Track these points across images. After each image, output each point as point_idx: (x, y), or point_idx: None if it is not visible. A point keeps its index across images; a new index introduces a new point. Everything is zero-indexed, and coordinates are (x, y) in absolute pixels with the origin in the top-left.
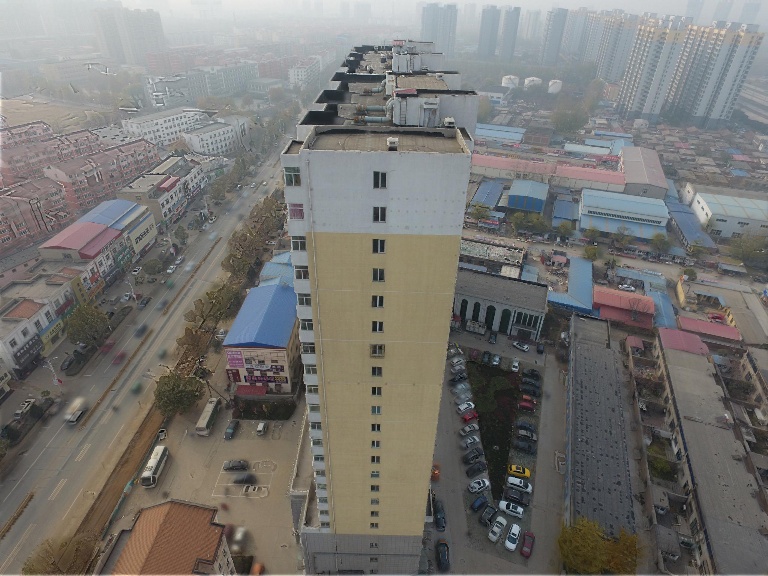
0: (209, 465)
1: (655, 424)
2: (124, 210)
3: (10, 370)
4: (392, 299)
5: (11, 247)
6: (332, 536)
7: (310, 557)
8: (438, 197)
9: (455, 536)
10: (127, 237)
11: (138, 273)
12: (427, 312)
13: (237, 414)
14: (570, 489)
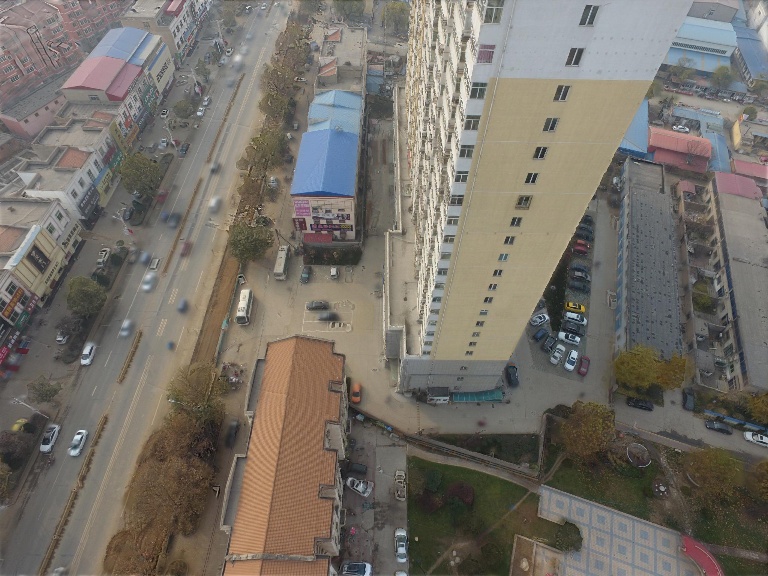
0: (293, 305)
1: (700, 265)
2: (137, 41)
3: (76, 221)
4: (556, 150)
5: (22, 87)
6: (430, 362)
7: (406, 378)
8: (646, 36)
9: (521, 360)
10: (148, 74)
11: (167, 116)
12: (586, 163)
13: (308, 260)
14: (626, 322)
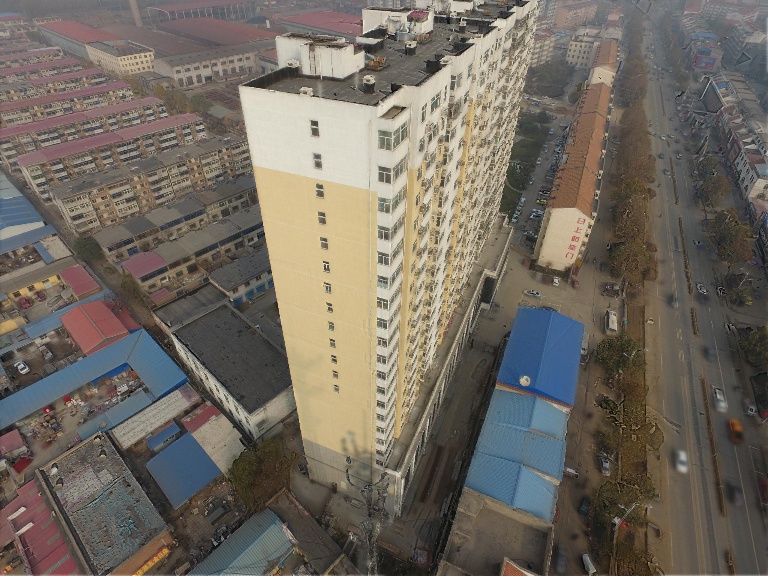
0: None
1: None
2: None
3: None
4: None
5: None
6: None
7: None
8: None
9: None
10: None
11: None
12: None
13: None
14: None
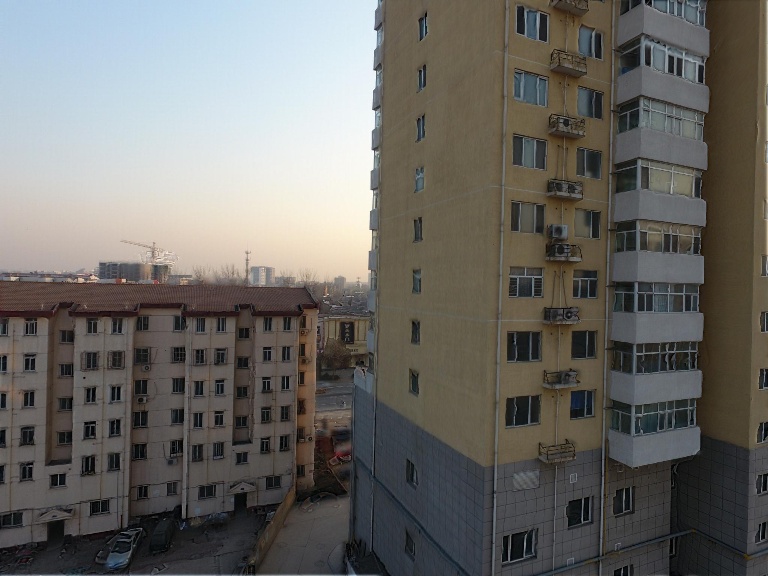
0: None
1: None
2: None
3: None
4: None
5: None
6: (372, 404)
7: None
8: None
9: None
10: None
11: None
12: None
13: None
14: None
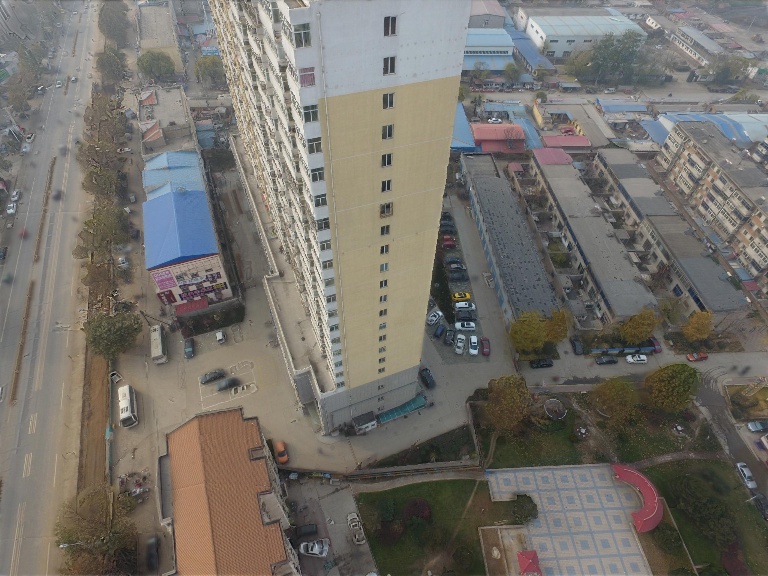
0: (184, 386)
1: (547, 229)
2: None
3: None
4: (400, 154)
5: None
6: (347, 392)
7: (328, 417)
8: (443, 37)
9: (430, 361)
10: None
11: None
12: (430, 160)
13: (187, 333)
14: (507, 295)
